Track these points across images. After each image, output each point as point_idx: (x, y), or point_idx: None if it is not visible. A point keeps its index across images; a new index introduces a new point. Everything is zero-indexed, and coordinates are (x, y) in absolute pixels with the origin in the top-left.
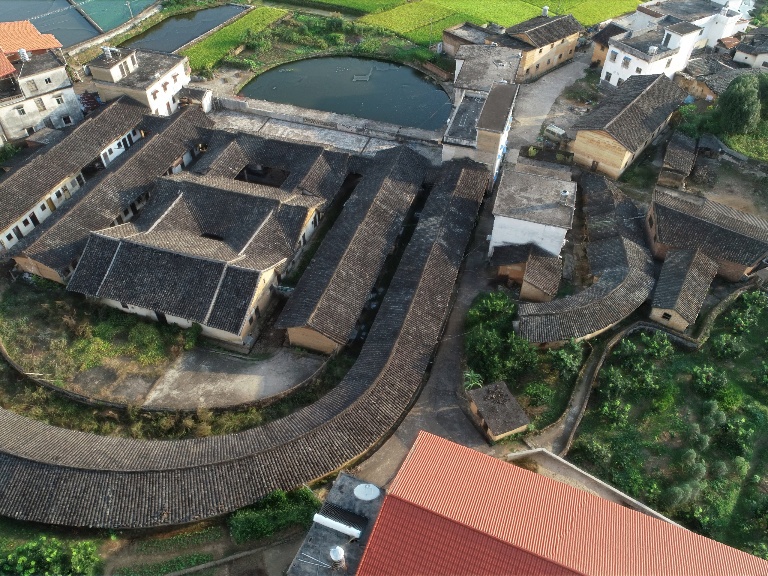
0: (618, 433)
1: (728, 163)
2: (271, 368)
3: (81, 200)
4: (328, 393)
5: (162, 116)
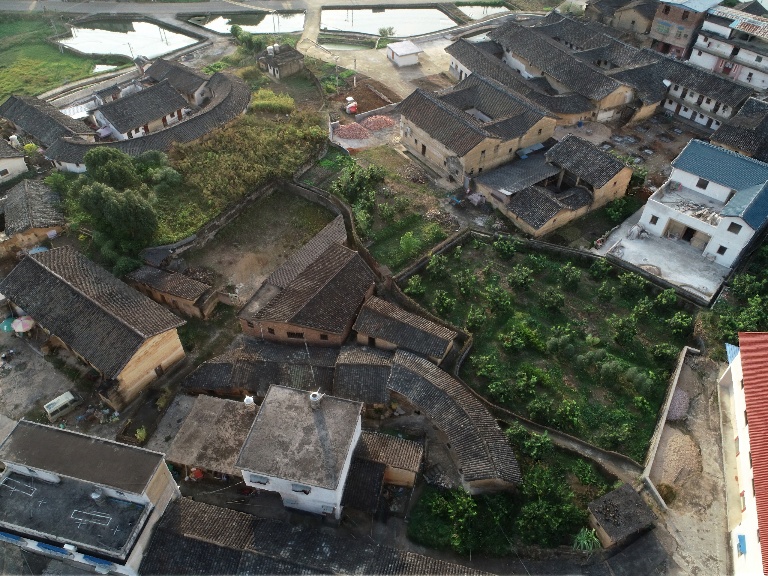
0: (580, 418)
1: (186, 252)
2: None
3: None
4: None
5: None
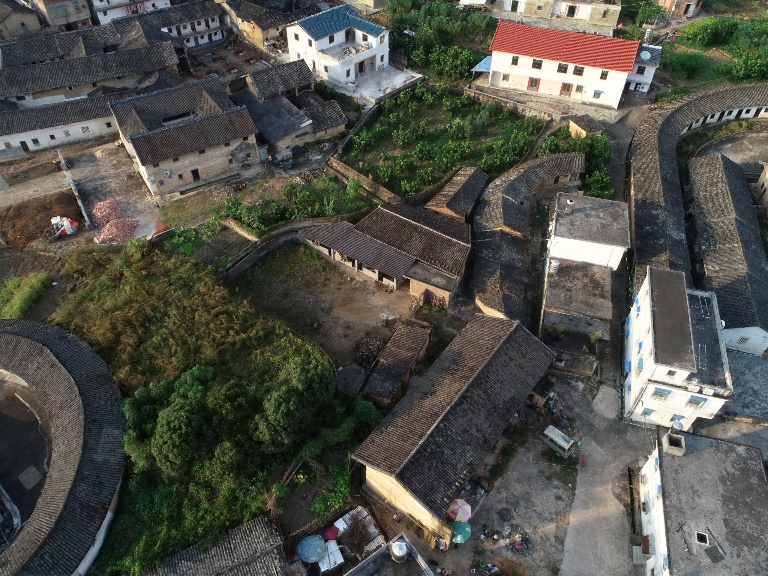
0: None
1: None
2: None
3: None
4: None
5: None
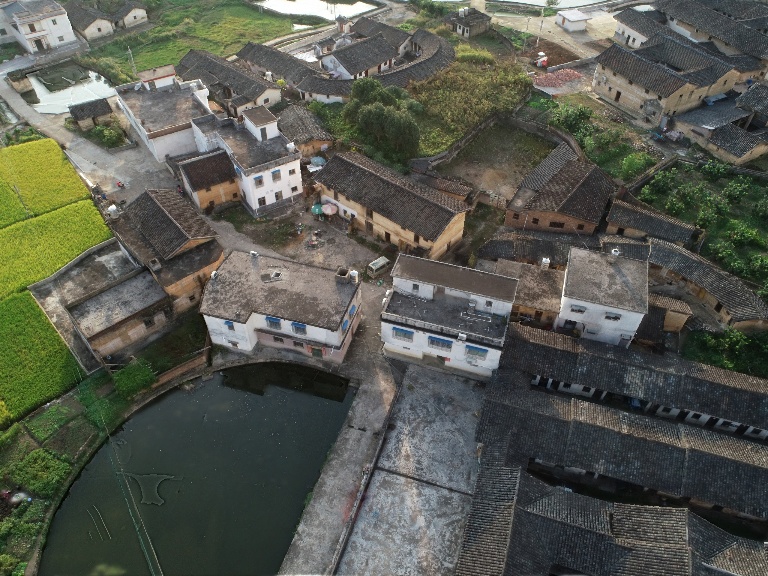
0: None
1: (438, 166)
2: None
3: None
4: None
5: None
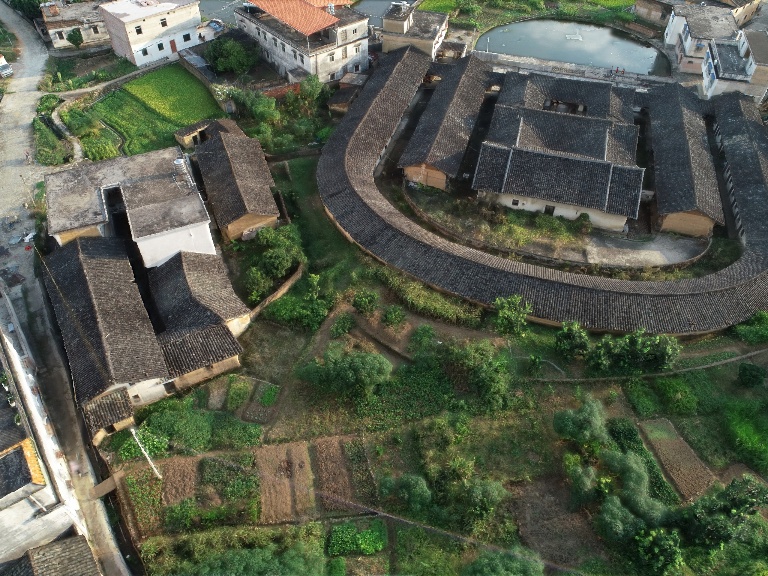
0: None
1: None
2: (660, 246)
3: (442, 123)
4: (743, 254)
5: None
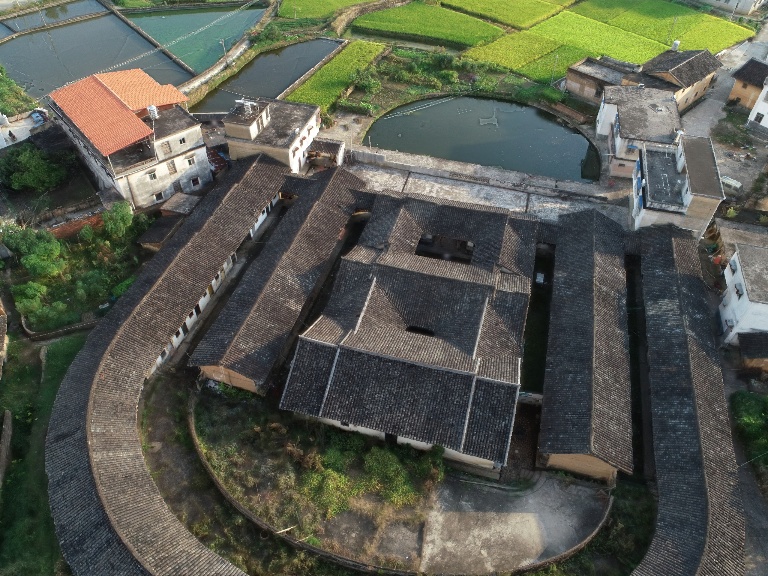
0: None
1: None
2: (541, 501)
3: (263, 290)
4: (650, 547)
5: (304, 176)
